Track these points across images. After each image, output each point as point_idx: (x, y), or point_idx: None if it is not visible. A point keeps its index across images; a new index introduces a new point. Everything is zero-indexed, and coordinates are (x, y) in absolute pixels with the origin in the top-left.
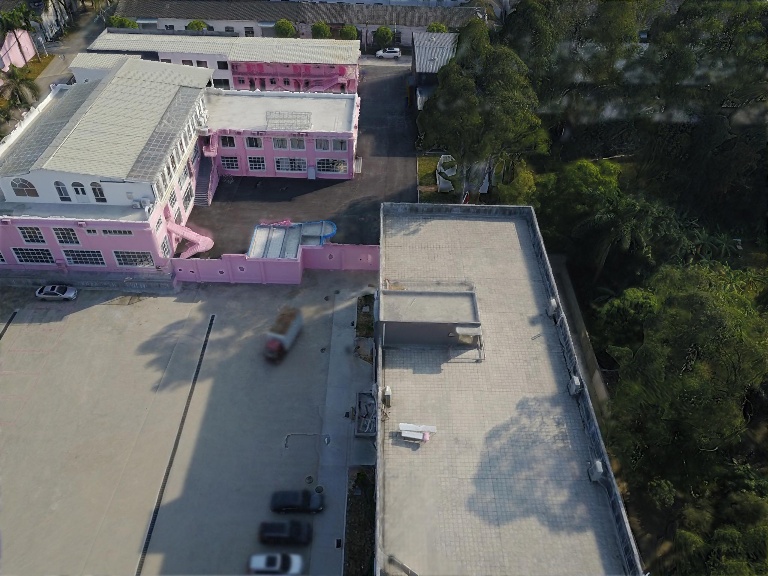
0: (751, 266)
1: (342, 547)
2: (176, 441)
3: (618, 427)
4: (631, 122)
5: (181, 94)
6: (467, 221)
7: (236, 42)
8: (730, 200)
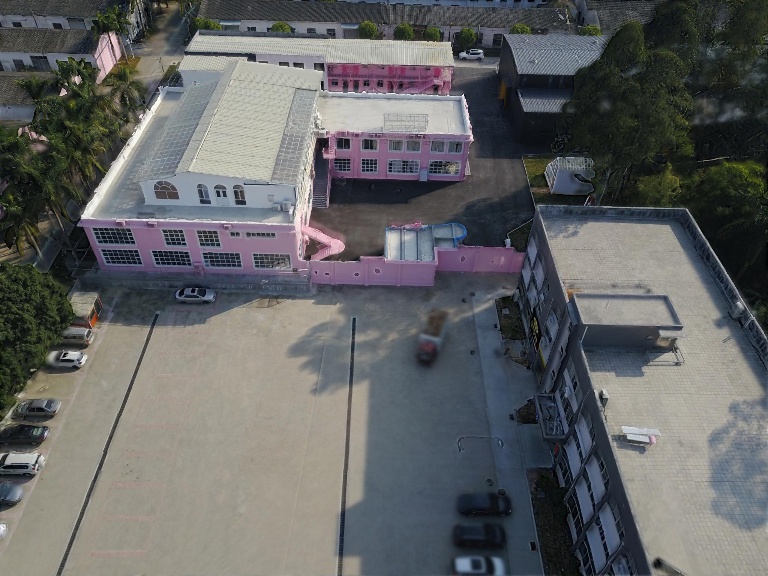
0: None
1: (538, 550)
2: (346, 444)
3: None
4: (767, 124)
5: (298, 96)
6: (622, 223)
7: (330, 44)
8: None
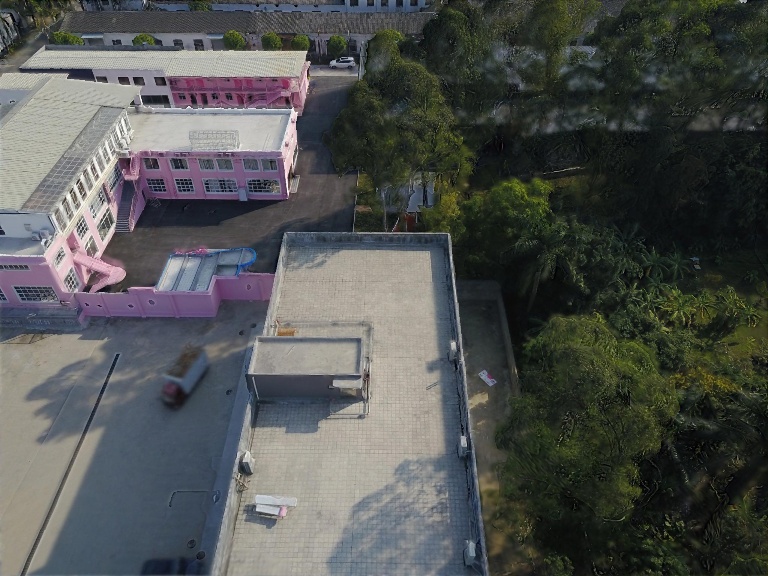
0: (708, 288)
1: None
2: (55, 499)
3: (507, 496)
4: (568, 136)
5: (101, 115)
6: (378, 251)
7: (176, 56)
8: (683, 217)
